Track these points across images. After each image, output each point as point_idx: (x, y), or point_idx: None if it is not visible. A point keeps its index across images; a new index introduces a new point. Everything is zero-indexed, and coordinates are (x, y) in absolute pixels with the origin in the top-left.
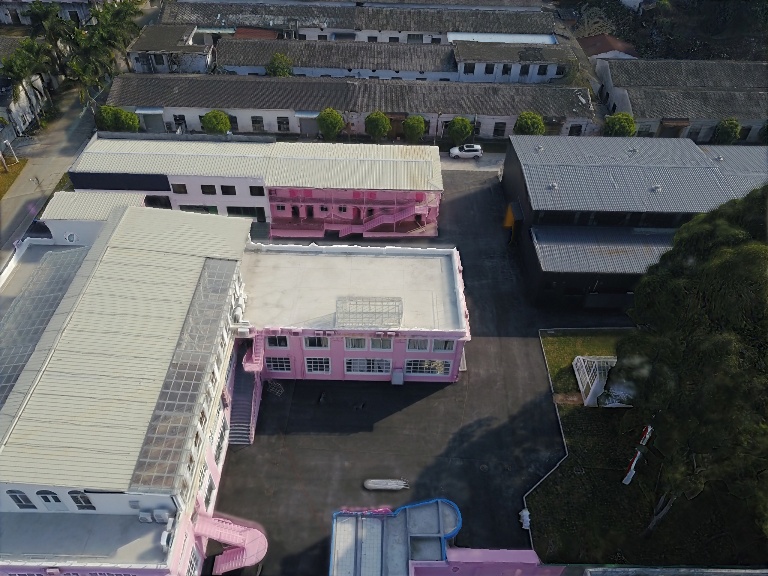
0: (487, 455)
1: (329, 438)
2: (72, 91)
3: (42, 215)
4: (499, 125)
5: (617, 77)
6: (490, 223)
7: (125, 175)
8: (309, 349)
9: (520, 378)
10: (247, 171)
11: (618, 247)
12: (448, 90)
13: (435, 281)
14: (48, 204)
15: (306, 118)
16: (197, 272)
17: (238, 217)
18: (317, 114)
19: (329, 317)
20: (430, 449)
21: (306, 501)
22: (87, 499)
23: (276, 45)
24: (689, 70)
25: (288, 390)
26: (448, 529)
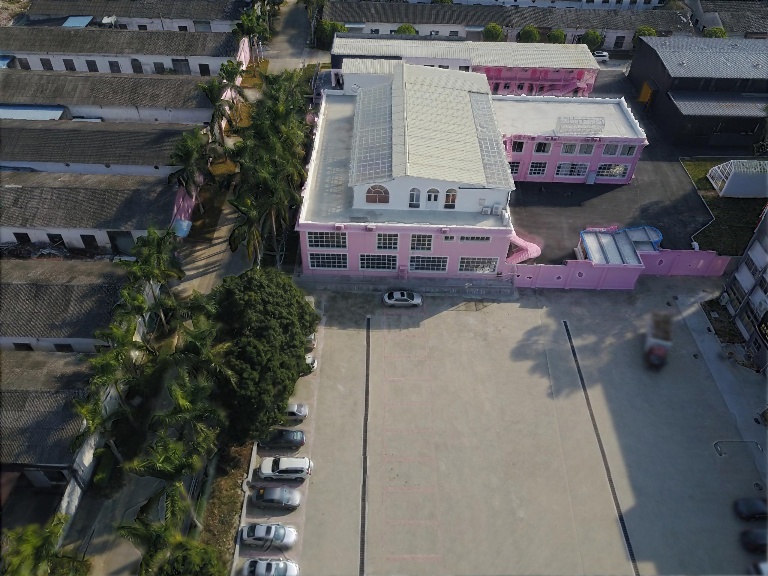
0: (661, 218)
1: (554, 209)
2: (277, 17)
3: (342, 71)
4: (619, 38)
5: (706, 6)
6: (627, 100)
7: (372, 57)
8: (536, 154)
9: (673, 182)
10: (456, 56)
11: (732, 104)
12: (580, 12)
13: (613, 116)
14: None
15: (474, 31)
16: (467, 98)
17: None
18: (482, 28)
19: (550, 132)
20: (623, 215)
21: (551, 237)
22: (454, 198)
23: None
24: (762, 1)
25: (517, 186)
26: (655, 239)
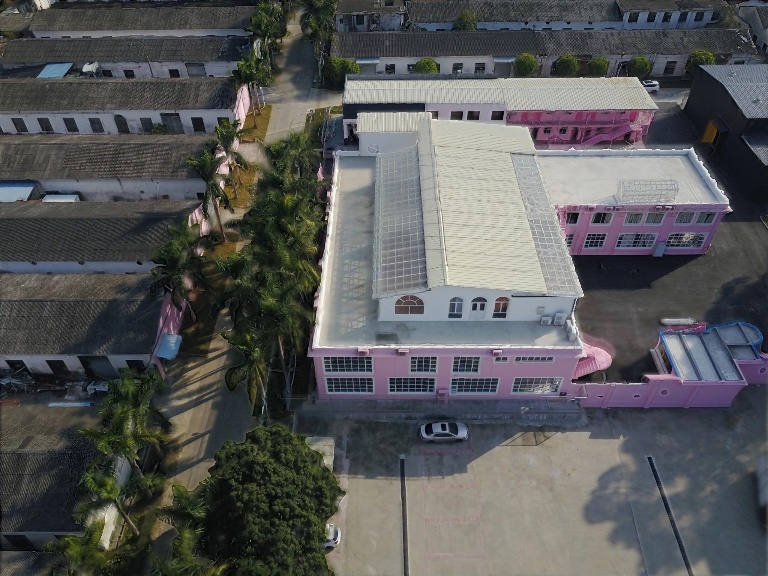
0: (751, 302)
1: (618, 293)
2: (280, 52)
3: (357, 129)
4: (670, 64)
5: (766, 20)
6: (687, 141)
7: (390, 105)
8: (593, 225)
9: (758, 250)
10: (487, 99)
11: None
12: (623, 35)
13: (683, 173)
14: (357, 122)
15: (503, 63)
16: (510, 162)
17: (517, 126)
18: (513, 59)
19: (610, 198)
20: (703, 299)
21: (619, 334)
22: (506, 306)
23: (458, 4)
24: None
25: None
26: (754, 341)
